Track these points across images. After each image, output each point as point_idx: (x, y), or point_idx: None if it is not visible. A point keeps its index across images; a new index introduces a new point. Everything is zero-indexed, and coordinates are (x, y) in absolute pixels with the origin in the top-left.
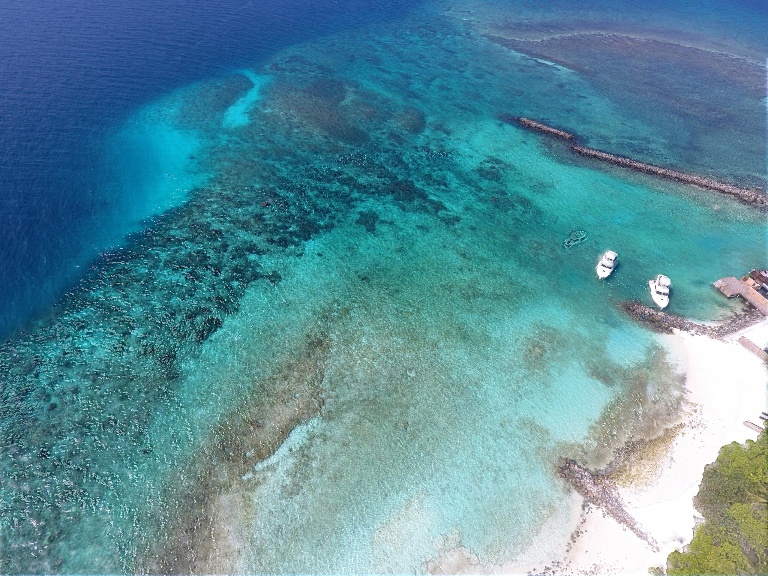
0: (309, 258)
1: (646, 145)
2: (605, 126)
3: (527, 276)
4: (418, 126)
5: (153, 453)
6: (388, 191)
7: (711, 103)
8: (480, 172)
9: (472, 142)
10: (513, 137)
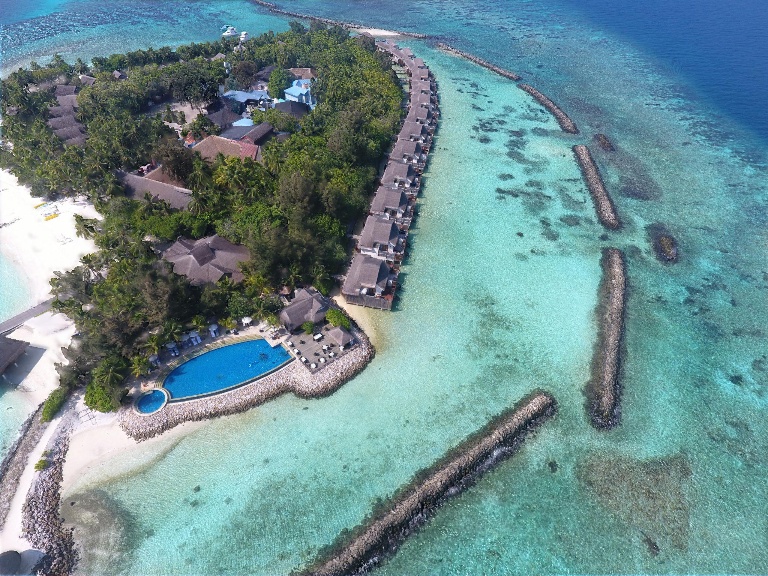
0: (97, 28)
1: (315, 11)
2: (304, 5)
3: (193, 36)
4: (195, 1)
5: (5, 54)
6: (154, 16)
7: (383, 1)
8: (209, 14)
9: (219, 7)
10: (244, 6)
